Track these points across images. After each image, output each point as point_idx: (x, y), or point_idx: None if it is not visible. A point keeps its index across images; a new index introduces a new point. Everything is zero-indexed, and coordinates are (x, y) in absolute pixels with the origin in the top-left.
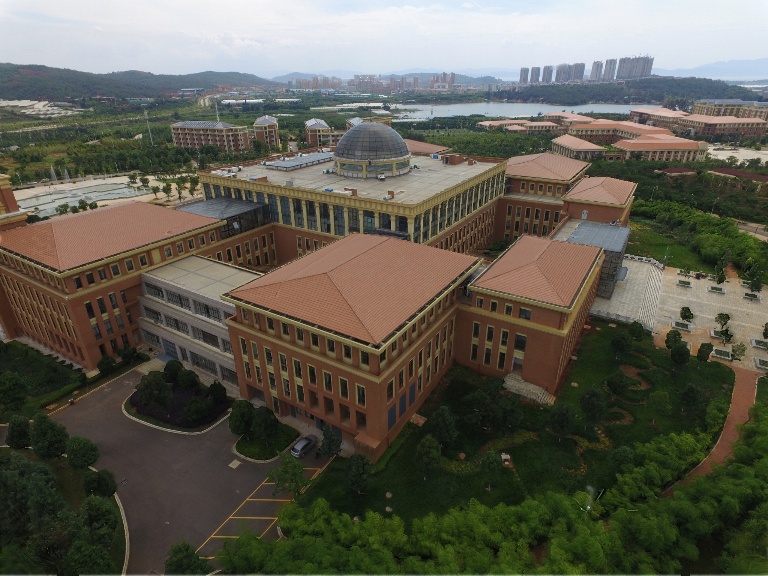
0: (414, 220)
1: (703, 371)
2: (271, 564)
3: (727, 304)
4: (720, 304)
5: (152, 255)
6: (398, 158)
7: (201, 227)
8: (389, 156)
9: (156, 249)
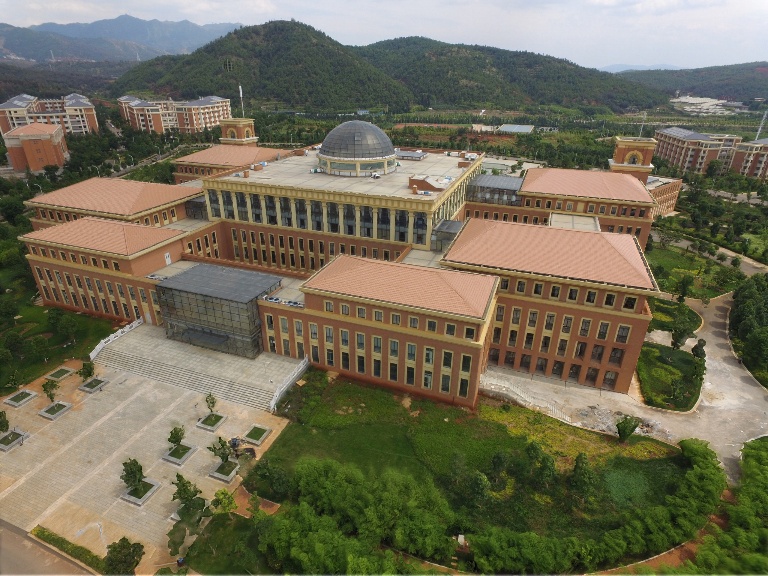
0: (211, 193)
1: (5, 375)
2: None
3: (130, 449)
4: (133, 441)
5: (213, 171)
6: (332, 157)
7: (237, 166)
8: (327, 153)
9: (215, 169)
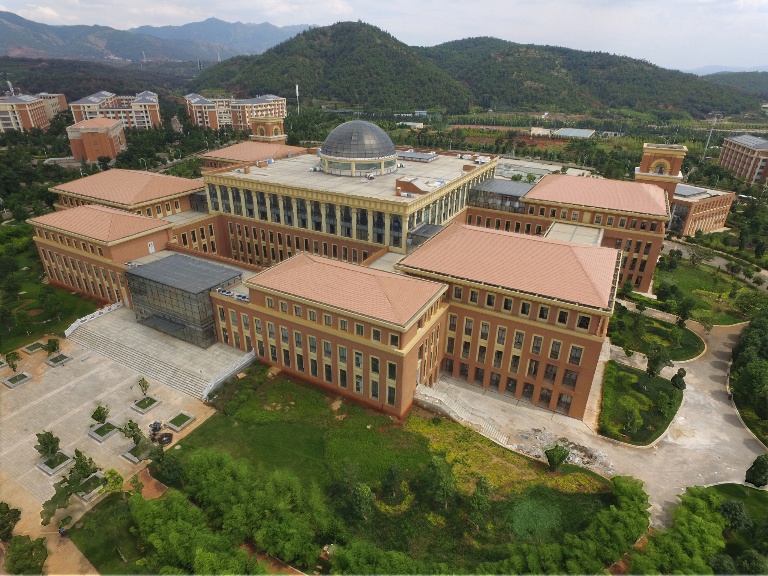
0: (211, 187)
1: None
2: None
3: (64, 422)
4: (70, 415)
5: None
6: (329, 156)
7: None
8: (325, 152)
9: None
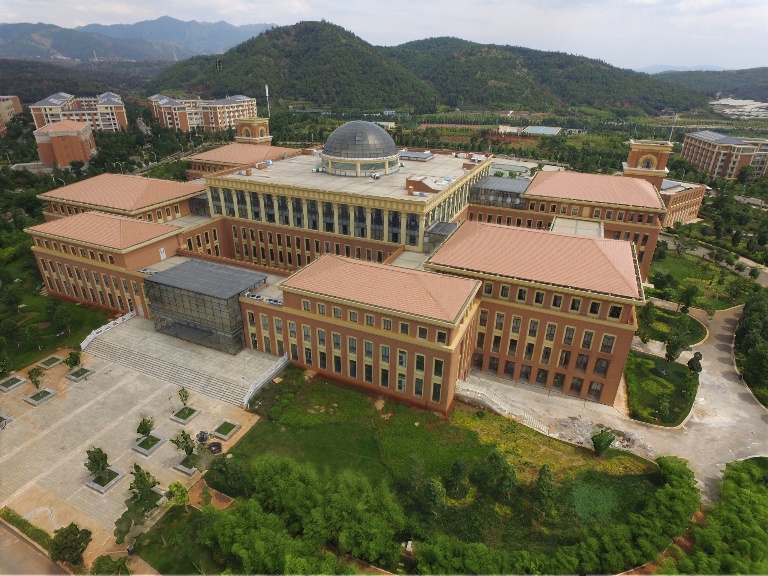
0: (213, 190)
1: None
2: (6, 233)
3: (103, 438)
4: (108, 430)
5: None
6: (333, 157)
7: None
8: (329, 153)
9: (226, 167)
